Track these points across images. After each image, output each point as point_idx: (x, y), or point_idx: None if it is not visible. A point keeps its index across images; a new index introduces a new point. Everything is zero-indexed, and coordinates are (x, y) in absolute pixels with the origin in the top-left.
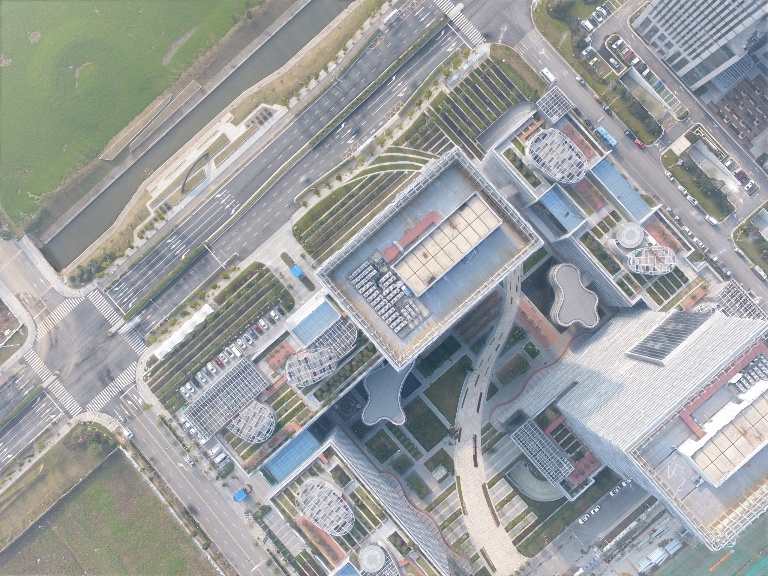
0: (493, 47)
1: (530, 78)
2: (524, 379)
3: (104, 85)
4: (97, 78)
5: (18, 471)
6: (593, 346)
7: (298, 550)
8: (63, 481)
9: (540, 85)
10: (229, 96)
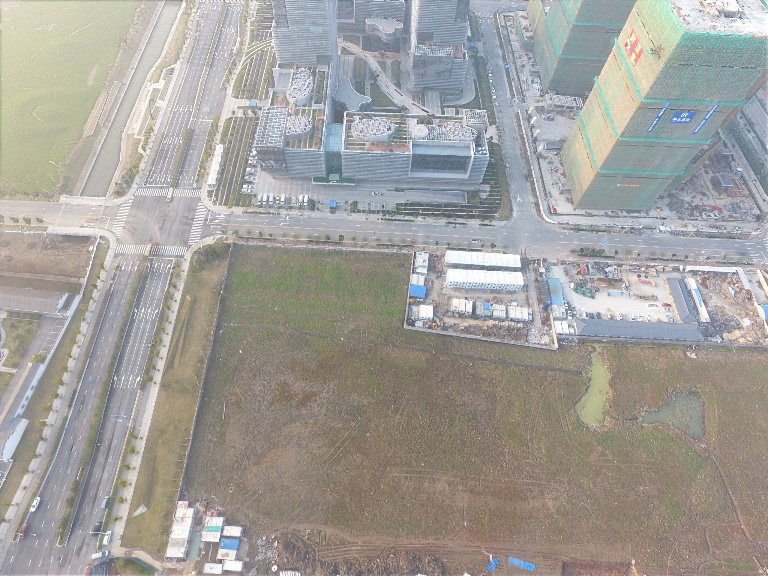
0: (257, 0)
1: None
2: (405, 73)
3: (58, 109)
4: (51, 109)
5: (172, 313)
6: None
7: (394, 206)
8: (212, 288)
9: None
10: (141, 80)
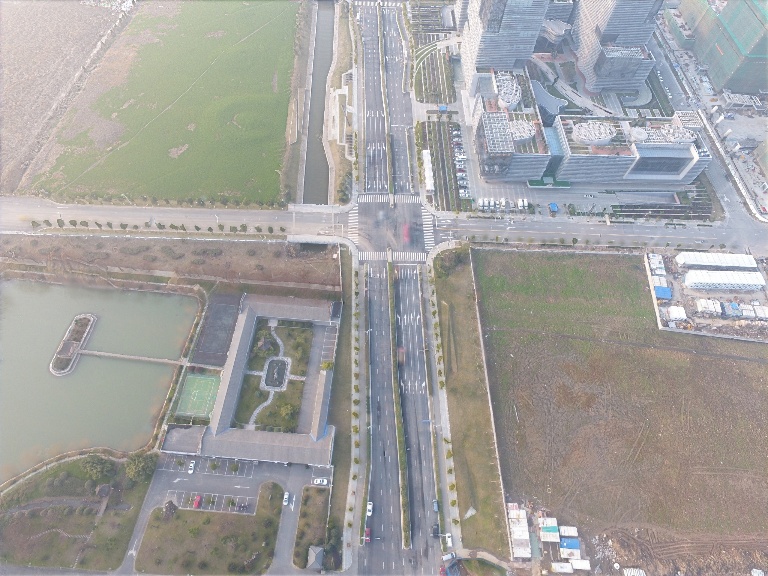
0: None
1: (434, 2)
2: (577, 74)
3: (256, 117)
4: (249, 117)
5: (434, 319)
6: (580, 34)
7: (610, 209)
8: (466, 293)
9: (440, 1)
10: (321, 86)
